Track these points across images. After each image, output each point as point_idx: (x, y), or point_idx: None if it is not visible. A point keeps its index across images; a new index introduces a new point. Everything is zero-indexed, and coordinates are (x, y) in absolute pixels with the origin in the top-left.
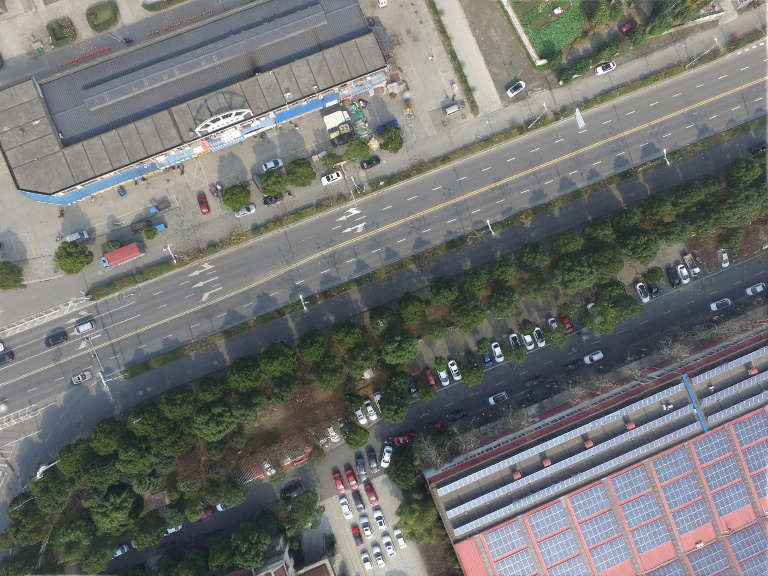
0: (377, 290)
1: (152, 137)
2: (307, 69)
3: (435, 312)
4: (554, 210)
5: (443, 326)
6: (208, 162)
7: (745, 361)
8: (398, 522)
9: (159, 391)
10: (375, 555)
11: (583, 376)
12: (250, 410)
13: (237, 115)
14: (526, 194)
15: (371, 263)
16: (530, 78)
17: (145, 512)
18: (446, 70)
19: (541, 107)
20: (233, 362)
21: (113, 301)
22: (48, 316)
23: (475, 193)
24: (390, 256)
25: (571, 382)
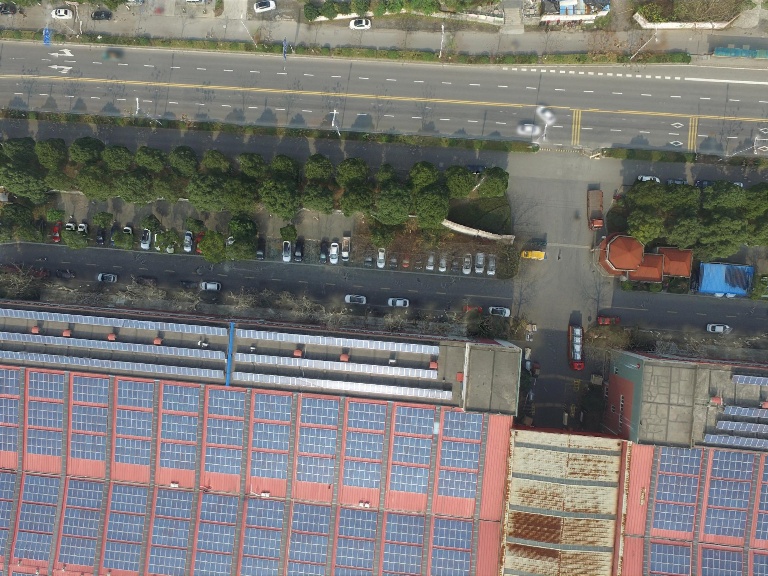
0: (53, 131)
1: None
2: None
3: None
4: (245, 136)
5: (61, 177)
6: None
7: (297, 341)
8: None
9: None
10: None
11: None
12: None
13: None
14: (227, 109)
15: (60, 105)
16: (285, 3)
17: None
18: None
19: (260, 26)
20: None
21: None
22: None
23: (180, 86)
24: (79, 107)
25: (134, 278)
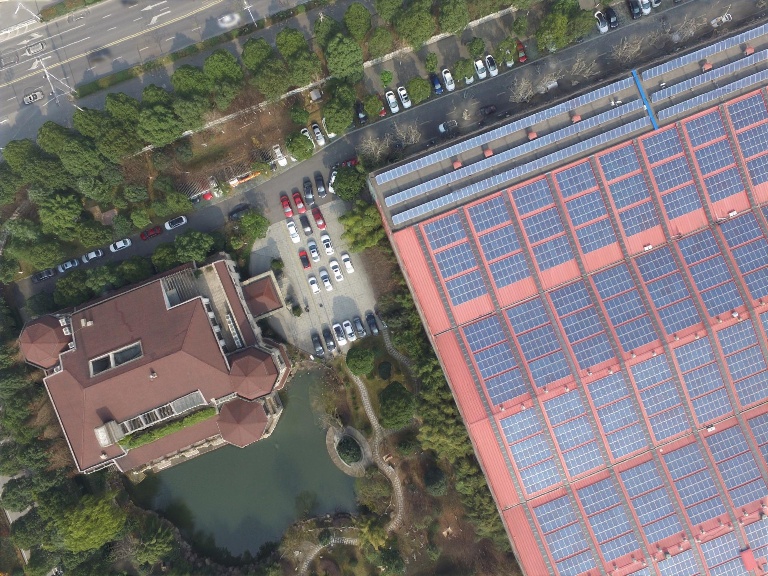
0: None
1: None
2: None
3: None
4: None
5: (387, 30)
6: None
7: (699, 58)
8: (342, 234)
9: None
10: (322, 278)
11: (536, 104)
12: (190, 102)
13: None
14: None
15: None
16: None
17: None
18: None
19: None
20: None
21: (63, 24)
22: (0, 37)
23: None
24: None
25: (516, 80)
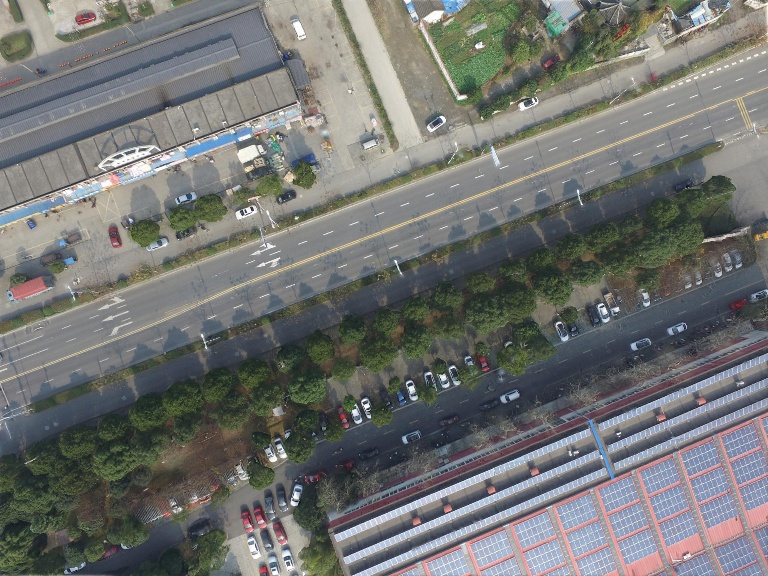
0: (290, 326)
1: (57, 171)
2: (217, 104)
3: (350, 349)
4: (473, 247)
5: (349, 366)
6: (121, 194)
7: (654, 407)
8: (302, 564)
9: (65, 426)
10: None
11: (498, 416)
12: (147, 451)
13: (142, 151)
14: (445, 230)
15: (285, 298)
16: (451, 113)
17: (47, 550)
18: (366, 104)
19: (457, 144)
20: (137, 400)
21: (21, 334)
22: None
23: (393, 229)
24: (305, 292)
25: (476, 426)
